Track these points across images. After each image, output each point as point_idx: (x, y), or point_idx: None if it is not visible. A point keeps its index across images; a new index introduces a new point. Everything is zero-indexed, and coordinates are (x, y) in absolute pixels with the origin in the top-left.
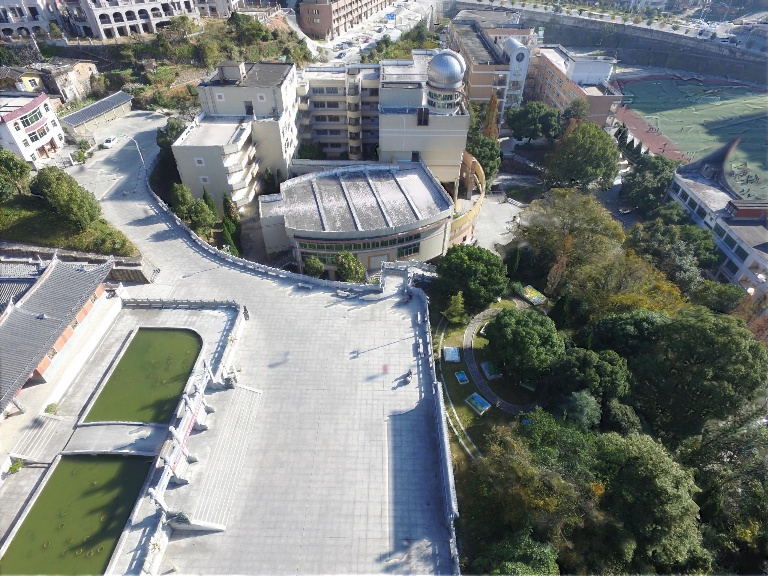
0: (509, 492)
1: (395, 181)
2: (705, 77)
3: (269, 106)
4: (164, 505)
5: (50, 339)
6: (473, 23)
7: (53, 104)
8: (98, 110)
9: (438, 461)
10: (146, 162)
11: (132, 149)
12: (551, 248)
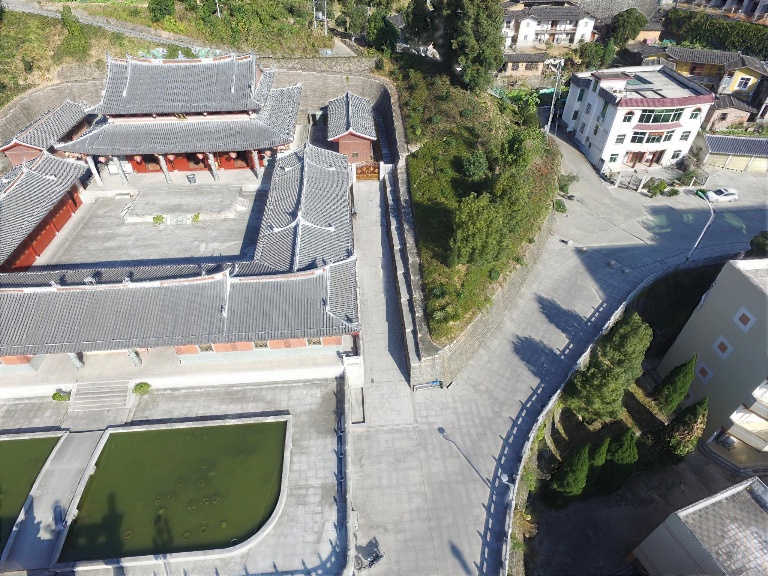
0: None
1: None
2: None
3: None
4: None
5: (188, 337)
6: None
7: (734, 116)
8: None
9: None
10: (713, 249)
11: (732, 221)
12: None
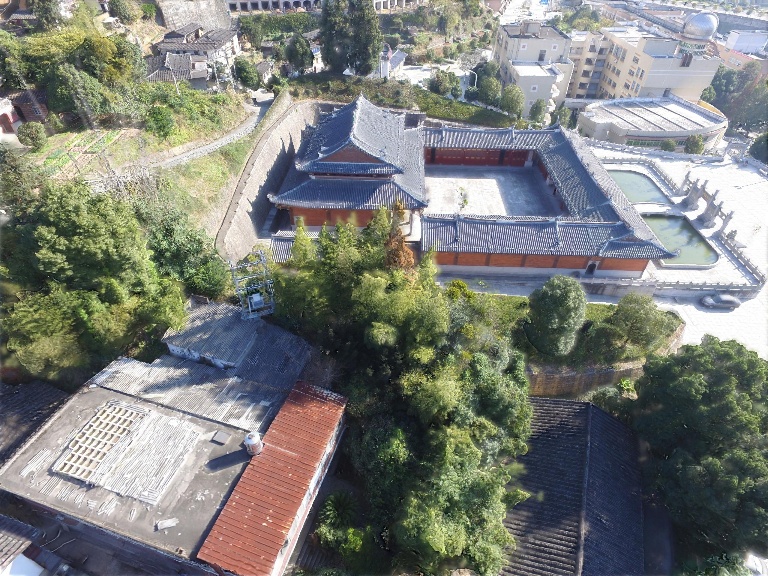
0: None
1: (663, 108)
2: None
3: (558, 54)
4: (725, 227)
5: None
6: (624, 7)
7: None
8: (396, 62)
9: None
10: None
11: None
12: None
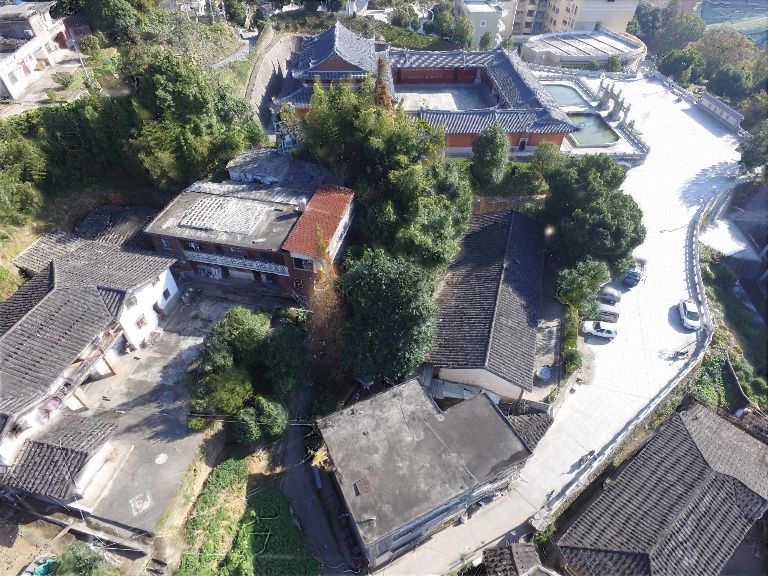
0: (760, 115)
1: (594, 39)
2: (730, 2)
3: None
4: None
5: None
6: None
7: None
8: (360, 5)
9: (715, 119)
10: None
11: None
12: (715, 60)
